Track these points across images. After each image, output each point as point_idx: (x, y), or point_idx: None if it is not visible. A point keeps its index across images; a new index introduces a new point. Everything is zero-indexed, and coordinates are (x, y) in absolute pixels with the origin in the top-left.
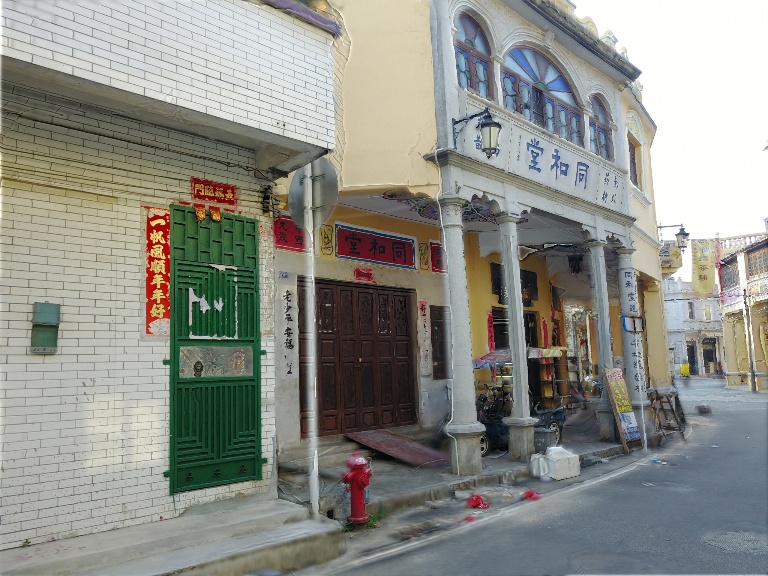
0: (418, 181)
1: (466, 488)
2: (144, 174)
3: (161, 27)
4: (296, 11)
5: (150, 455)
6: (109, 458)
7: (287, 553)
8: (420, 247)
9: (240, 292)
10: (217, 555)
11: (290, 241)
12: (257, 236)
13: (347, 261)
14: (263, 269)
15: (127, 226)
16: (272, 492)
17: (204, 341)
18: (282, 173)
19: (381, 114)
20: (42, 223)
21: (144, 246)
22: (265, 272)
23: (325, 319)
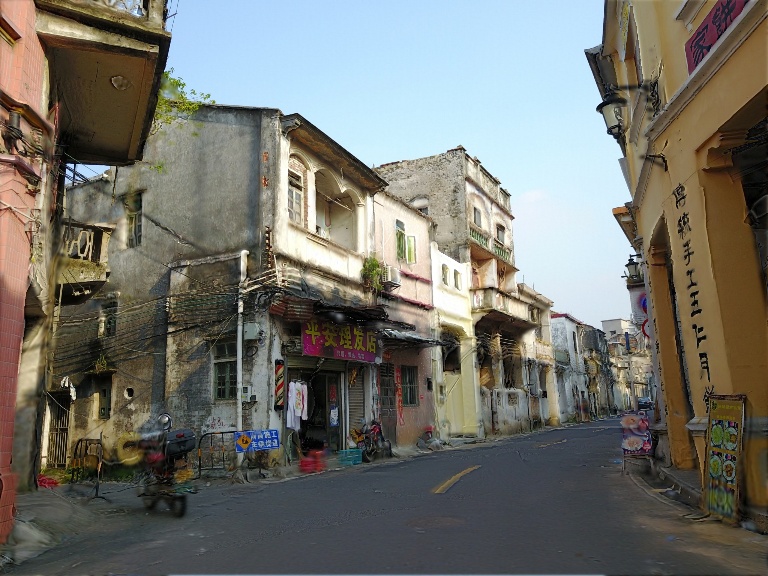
0: None
1: None
2: None
3: None
4: None
5: None
6: None
7: None
8: None
9: None
10: None
11: None
12: None
13: None
14: None
15: None
16: None
17: None
18: None
19: None
20: None
21: None
22: None
23: None
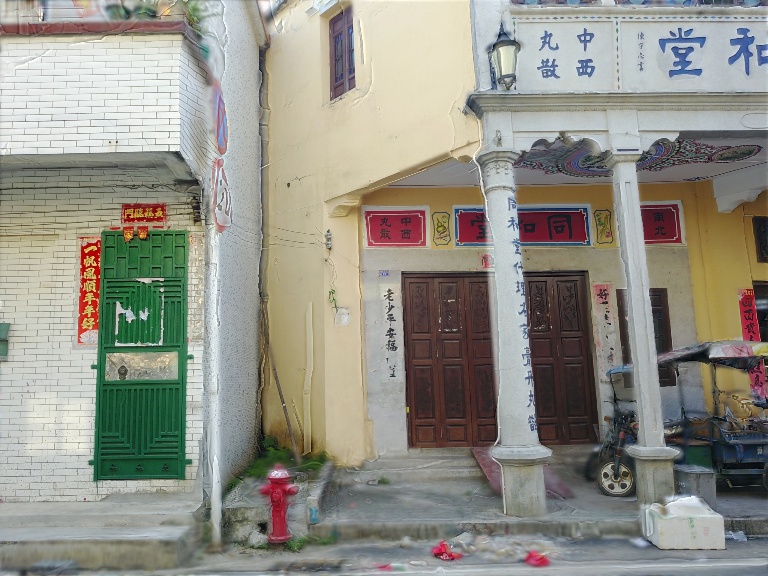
0: (458, 143)
1: (489, 531)
2: (81, 211)
3: (1, 95)
4: (136, 28)
5: (78, 445)
6: (45, 444)
7: (111, 551)
8: (596, 216)
9: (167, 301)
10: (48, 537)
11: (394, 237)
12: (187, 246)
13: (472, 248)
14: (193, 277)
15: (66, 256)
16: (197, 493)
17: (129, 348)
18: (191, 182)
19: (434, 75)
20: (3, 264)
21: (78, 271)
22: (195, 279)
23: (447, 316)
